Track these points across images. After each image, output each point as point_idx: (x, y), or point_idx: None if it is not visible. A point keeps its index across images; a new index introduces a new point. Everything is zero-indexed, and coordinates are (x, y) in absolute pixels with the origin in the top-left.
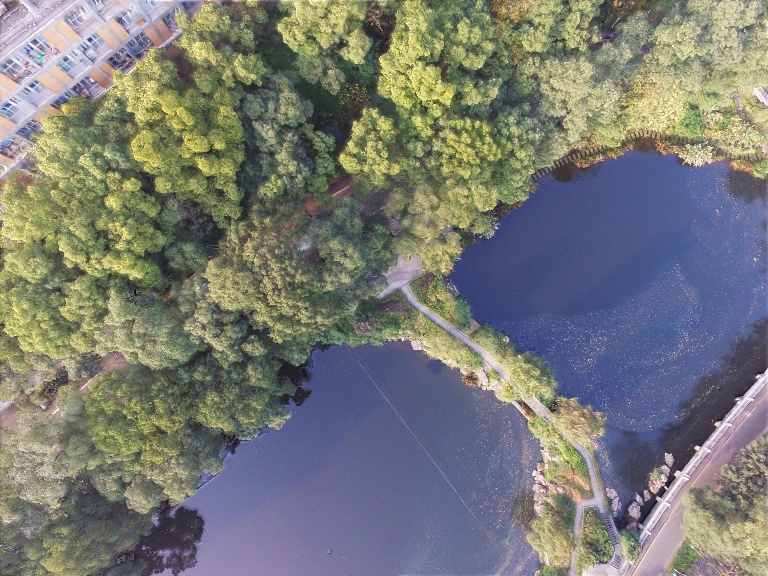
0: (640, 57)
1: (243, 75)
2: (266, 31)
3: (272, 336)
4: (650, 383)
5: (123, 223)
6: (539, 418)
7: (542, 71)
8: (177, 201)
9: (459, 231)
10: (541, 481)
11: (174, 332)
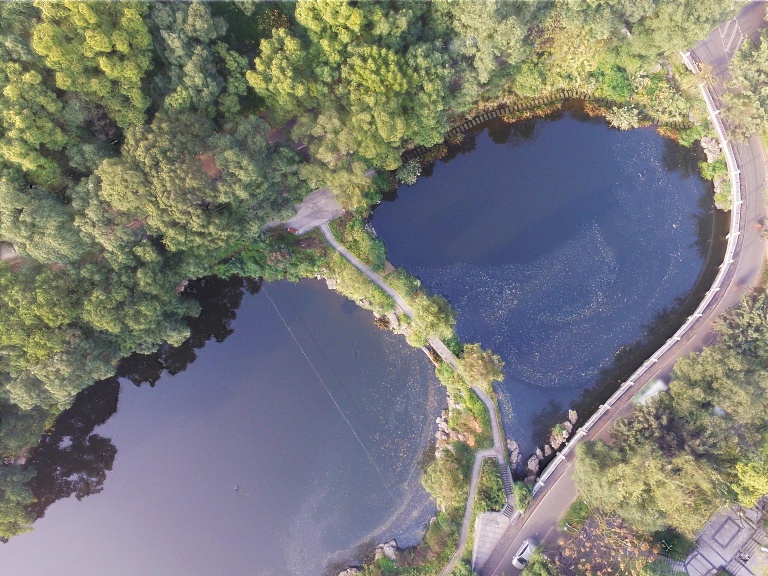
0: None
1: None
2: None
3: (164, 242)
4: (560, 339)
5: (18, 112)
6: (445, 364)
7: (455, 8)
8: (79, 100)
9: (382, 175)
10: (444, 428)
11: (64, 227)
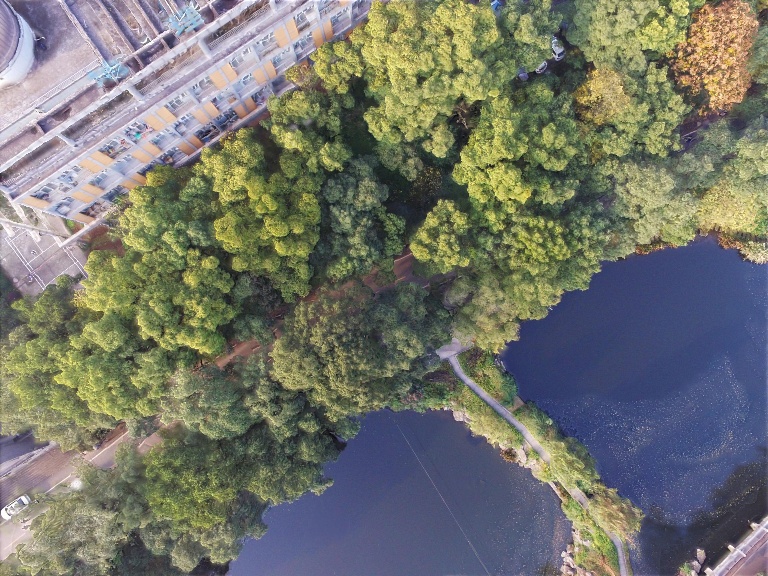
0: (719, 166)
1: (328, 164)
2: (351, 115)
3: (329, 415)
4: (689, 477)
5: (199, 300)
6: (574, 502)
7: (619, 173)
8: (250, 278)
9: None
10: (569, 563)
11: (236, 406)
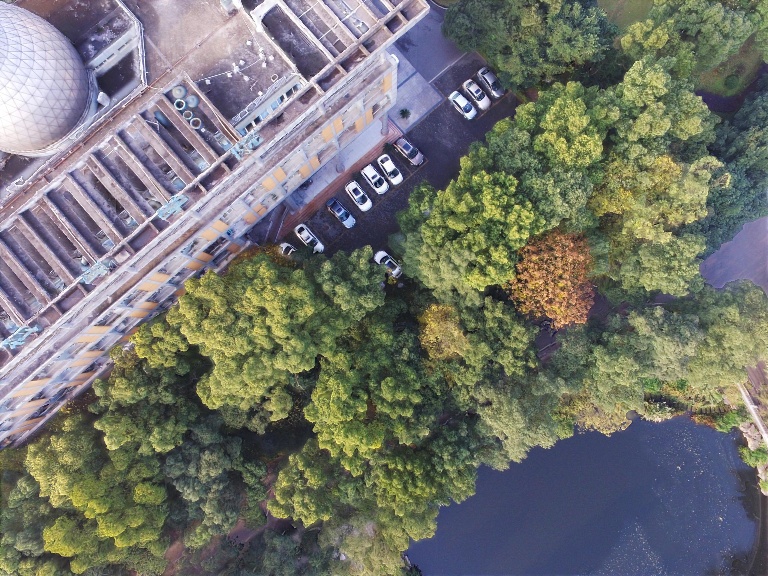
0: (581, 371)
1: None
2: (188, 380)
3: None
4: None
5: None
6: None
7: (477, 396)
8: None
9: None
10: None
11: None
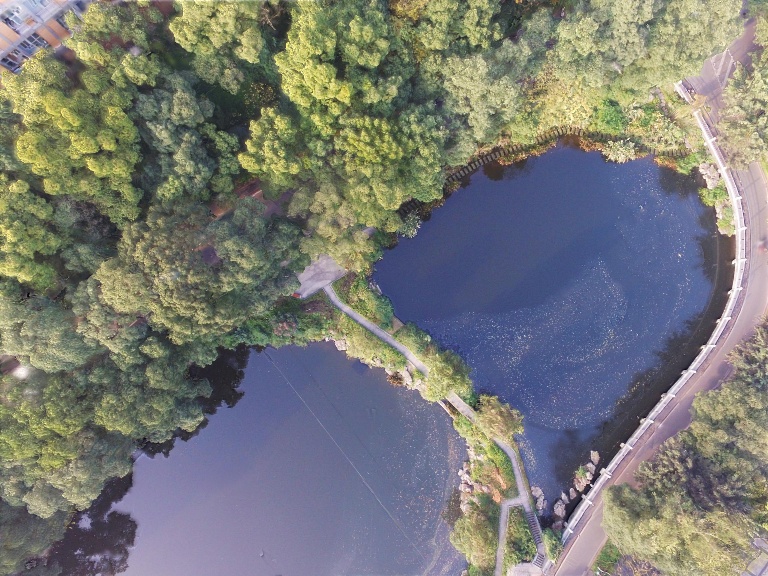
0: (545, 54)
1: (131, 75)
2: (161, 31)
3: (170, 338)
4: (575, 381)
5: (9, 225)
6: (463, 417)
7: (445, 69)
8: (70, 203)
9: None
10: (467, 480)
11: (67, 335)
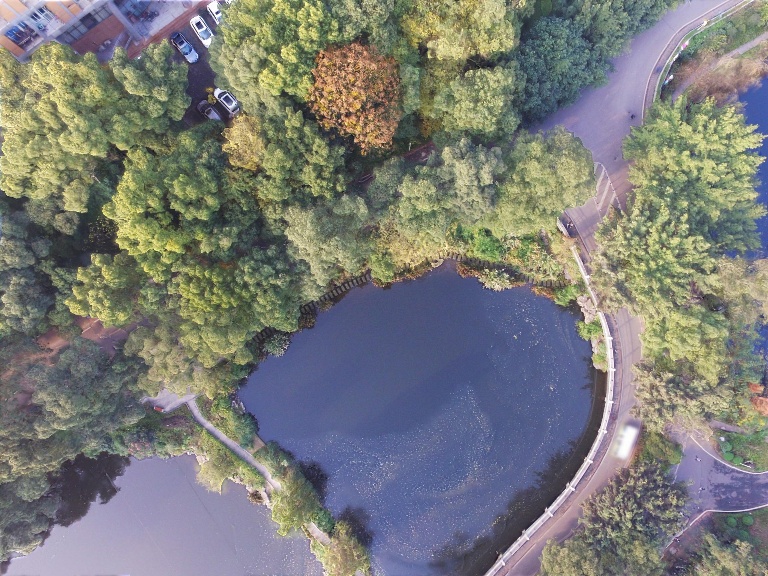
0: (393, 203)
1: None
2: None
3: None
4: (435, 511)
5: None
6: (317, 543)
7: (286, 217)
8: None
9: (250, 347)
10: None
11: None
